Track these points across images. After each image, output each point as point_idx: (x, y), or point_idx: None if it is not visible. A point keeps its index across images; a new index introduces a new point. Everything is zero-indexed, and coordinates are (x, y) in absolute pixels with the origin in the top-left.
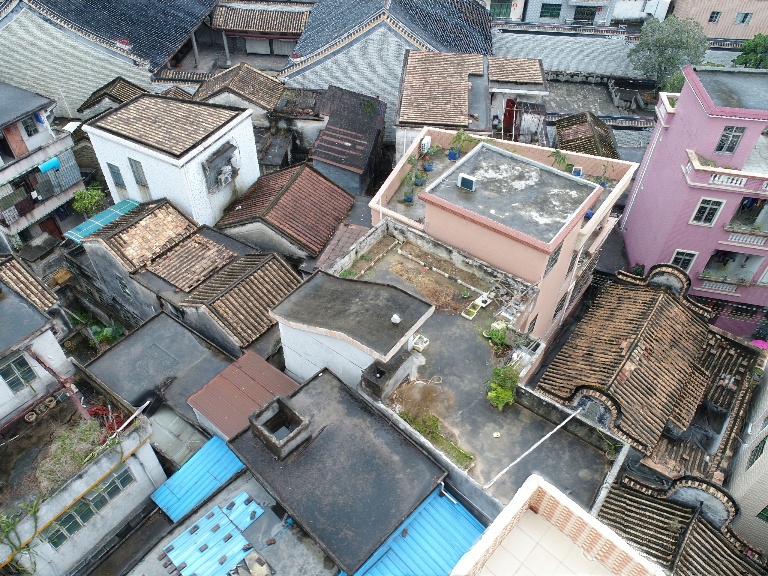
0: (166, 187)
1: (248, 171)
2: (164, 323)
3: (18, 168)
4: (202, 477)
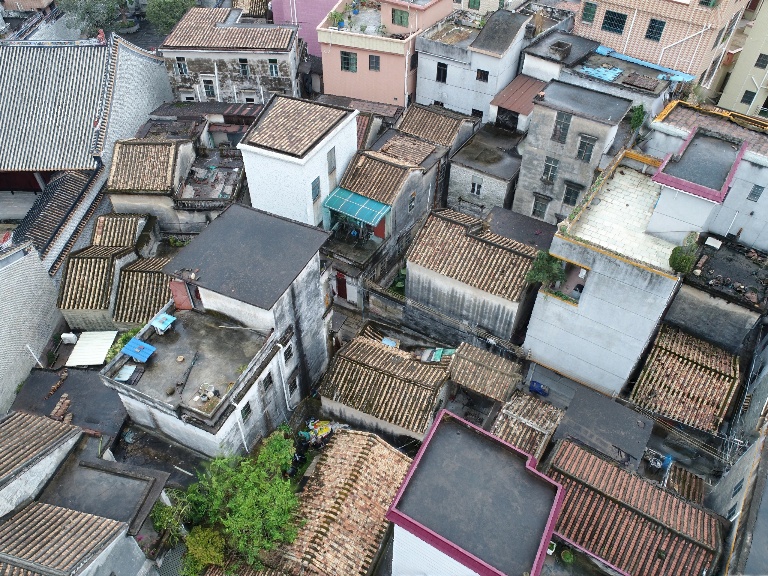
0: (346, 149)
1: None
2: (458, 158)
3: None
4: None
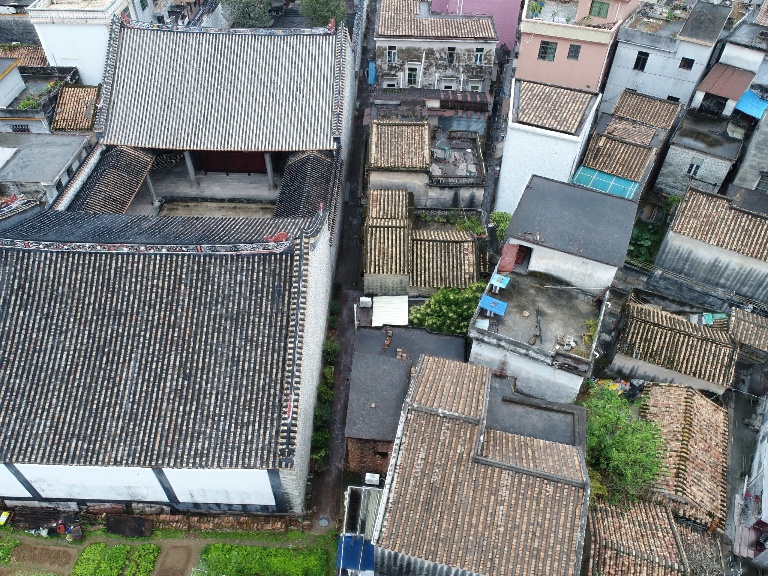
0: None
1: None
2: (677, 141)
3: None
4: (755, 110)
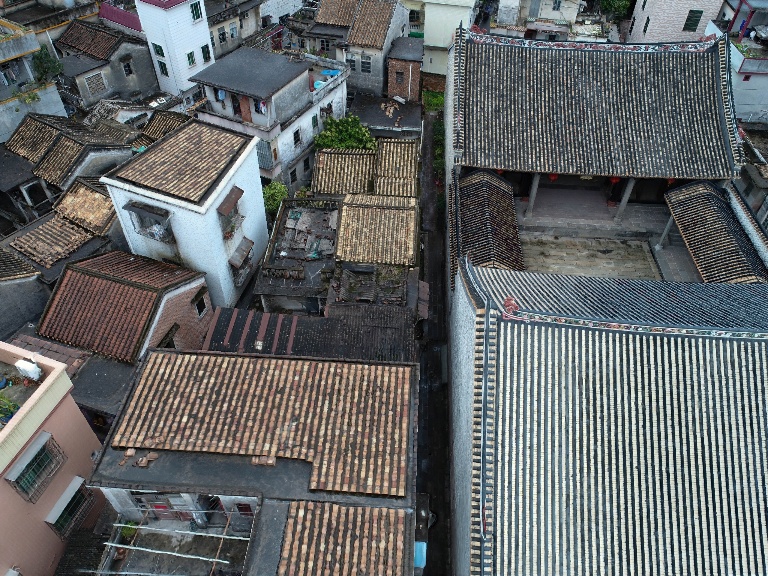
0: None
1: (200, 257)
2: None
3: (222, 122)
4: None
